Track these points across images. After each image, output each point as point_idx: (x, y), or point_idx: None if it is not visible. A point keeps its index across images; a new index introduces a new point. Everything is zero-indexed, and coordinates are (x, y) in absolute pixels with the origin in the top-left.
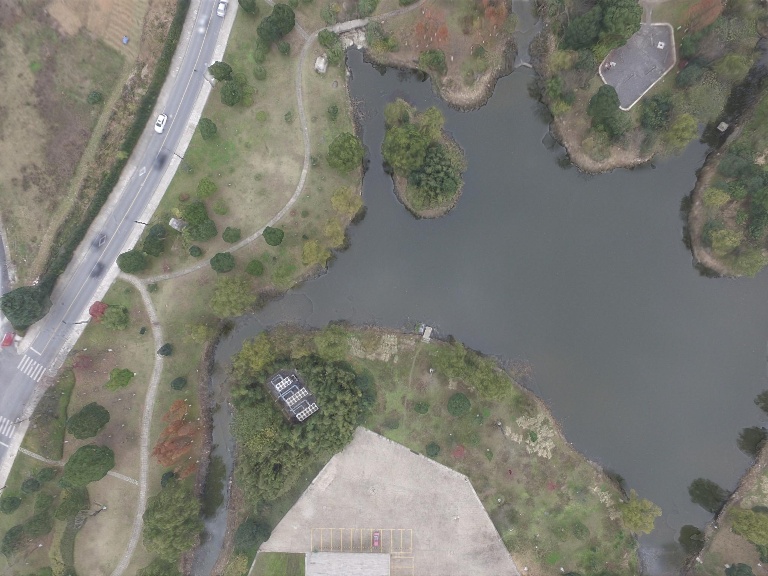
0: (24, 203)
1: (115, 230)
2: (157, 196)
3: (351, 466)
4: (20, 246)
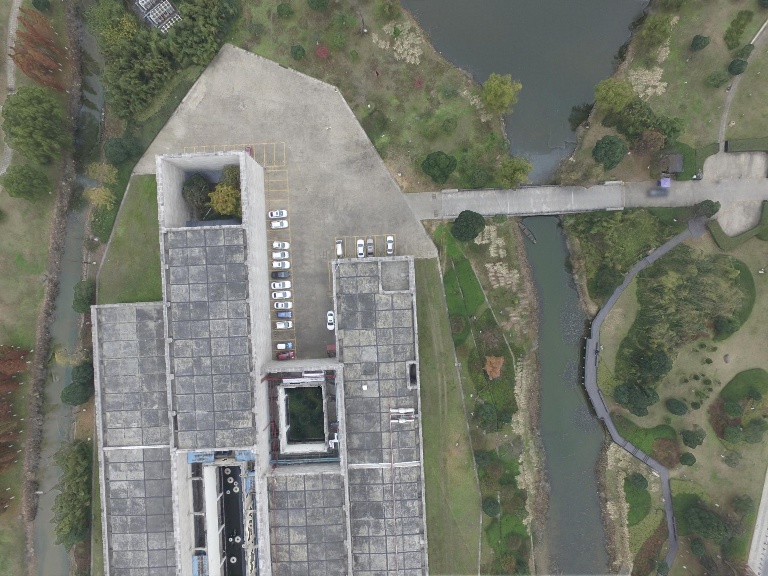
0: None
1: None
2: None
3: (220, 83)
4: None
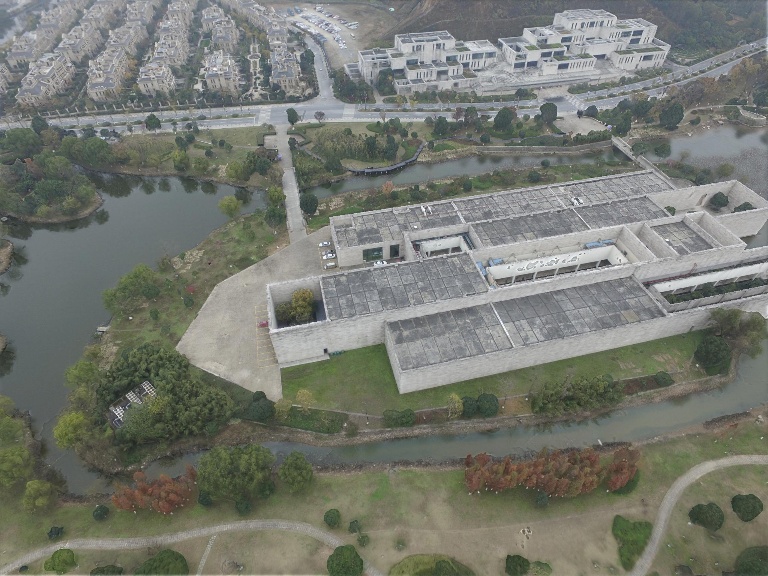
0: None
1: None
2: None
3: (205, 353)
4: None
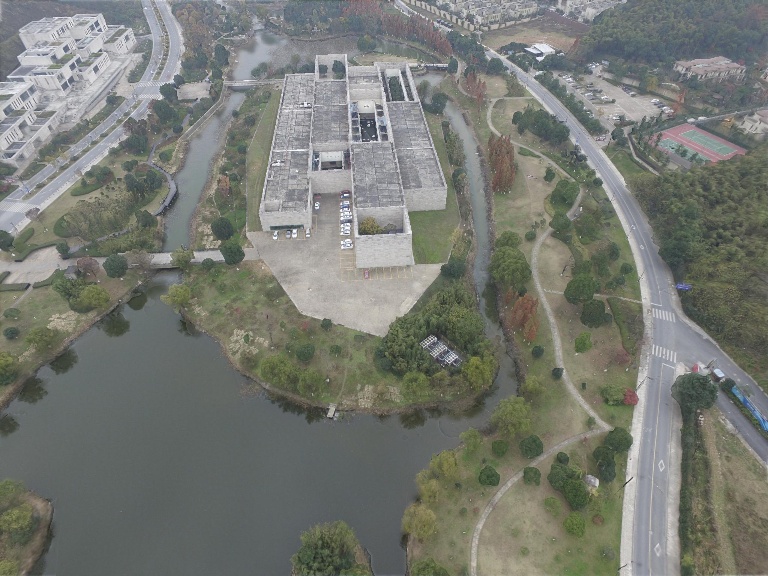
0: (763, 496)
1: (655, 478)
2: (628, 520)
3: (389, 313)
4: (738, 451)
